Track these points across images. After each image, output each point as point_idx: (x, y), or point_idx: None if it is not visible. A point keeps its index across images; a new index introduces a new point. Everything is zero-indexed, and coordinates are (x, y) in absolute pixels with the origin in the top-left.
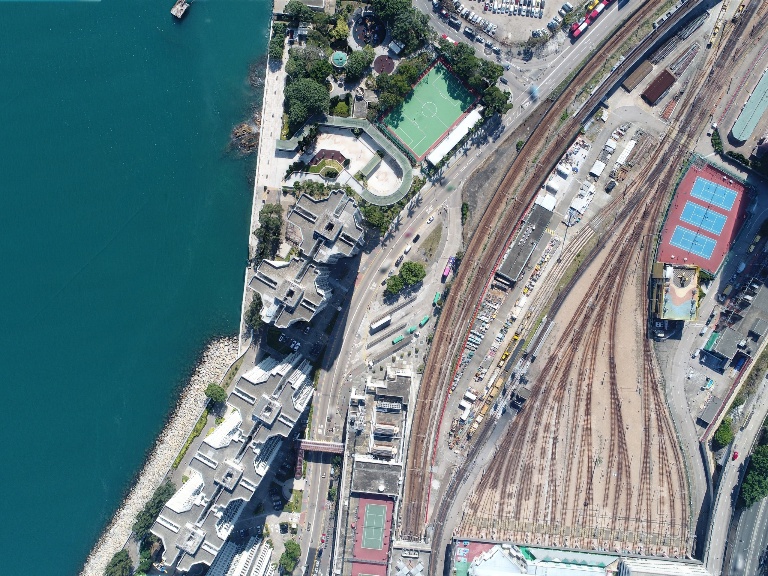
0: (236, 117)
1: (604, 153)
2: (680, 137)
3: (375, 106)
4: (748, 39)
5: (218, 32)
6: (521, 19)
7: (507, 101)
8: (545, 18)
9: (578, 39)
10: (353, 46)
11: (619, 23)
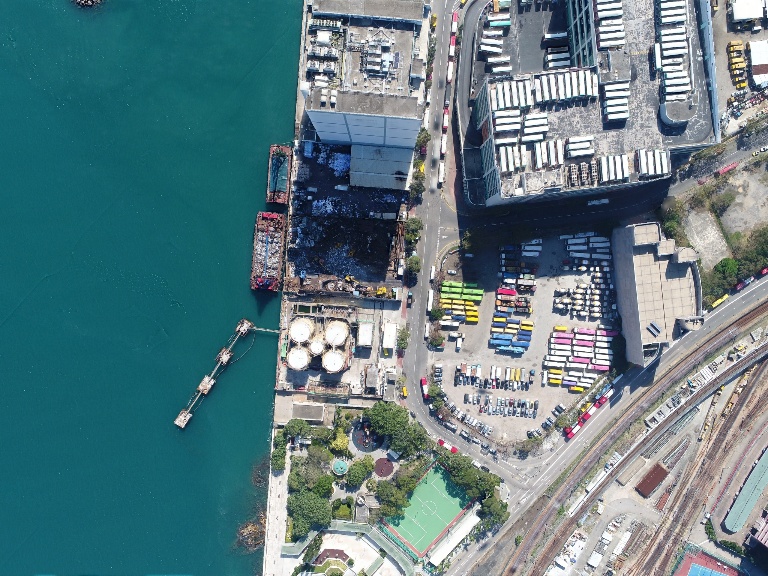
0: (241, 515)
1: (601, 545)
2: (674, 526)
3: (376, 514)
4: (738, 431)
5: (221, 438)
6: (516, 419)
7: (505, 498)
8: (539, 418)
9: (572, 437)
10: (353, 450)
11: (611, 420)
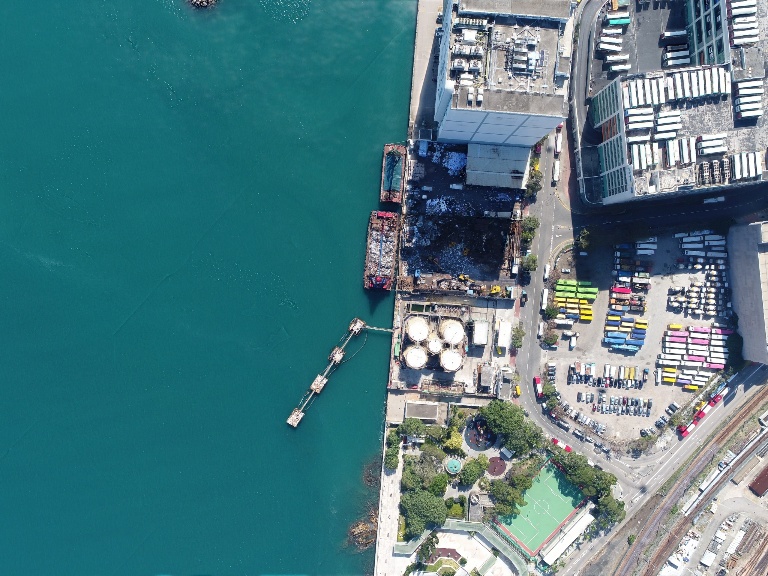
0: (352, 514)
1: (714, 544)
2: None
3: (490, 512)
4: None
5: (333, 437)
6: (629, 418)
7: (617, 497)
8: (652, 416)
9: None
10: (465, 449)
11: (725, 419)
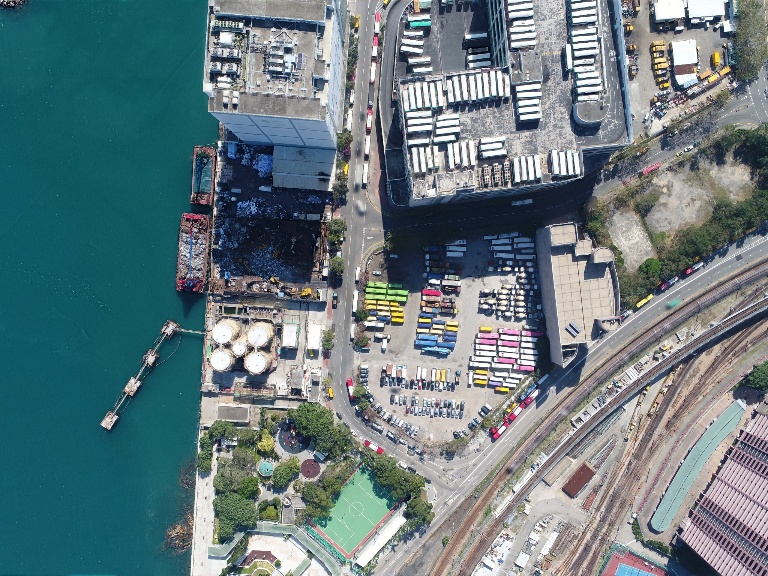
0: (170, 517)
1: (528, 545)
2: (601, 526)
3: (302, 515)
4: (664, 431)
5: (148, 440)
6: (442, 420)
7: (431, 499)
8: (465, 418)
9: (498, 438)
10: (279, 451)
11: (538, 421)
